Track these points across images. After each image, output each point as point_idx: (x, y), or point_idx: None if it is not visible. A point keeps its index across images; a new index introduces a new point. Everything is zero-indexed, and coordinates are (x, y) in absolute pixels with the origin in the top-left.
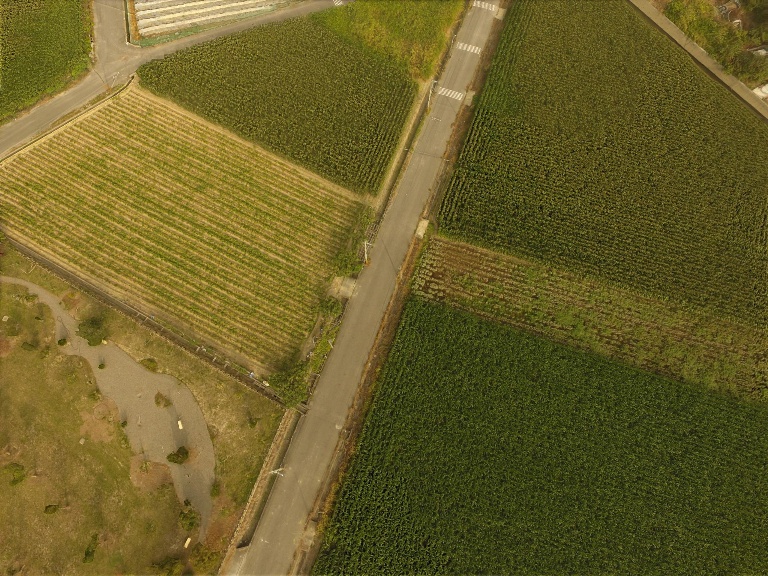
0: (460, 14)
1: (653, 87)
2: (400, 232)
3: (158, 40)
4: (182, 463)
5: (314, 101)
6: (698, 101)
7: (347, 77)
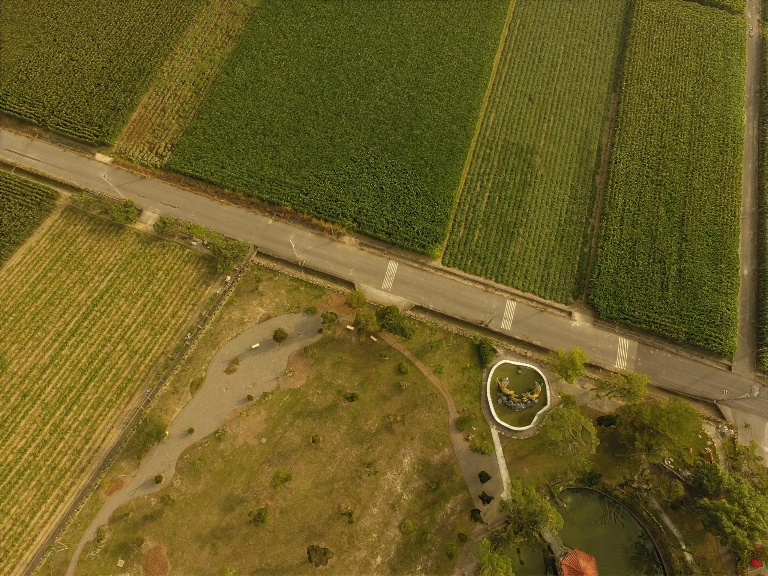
0: None
1: None
2: None
3: None
4: None
5: None
6: None
7: None
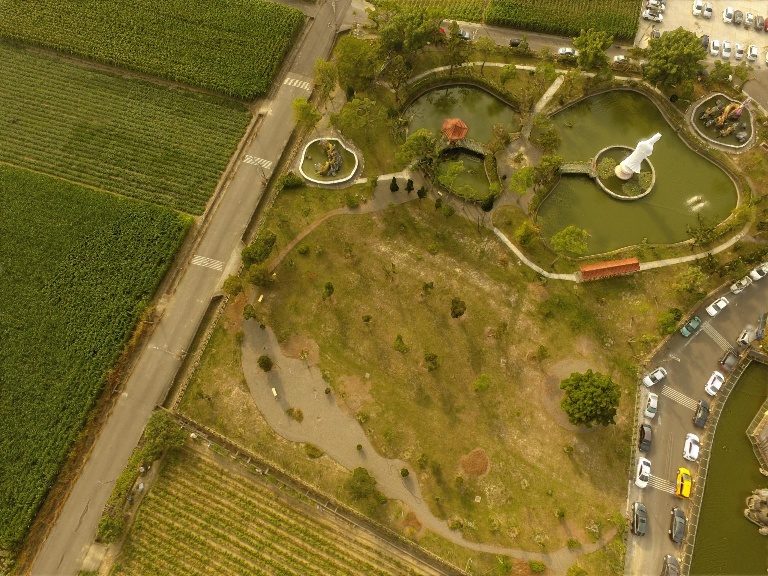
0: None
1: None
2: None
3: None
4: None
5: None
6: None
7: None
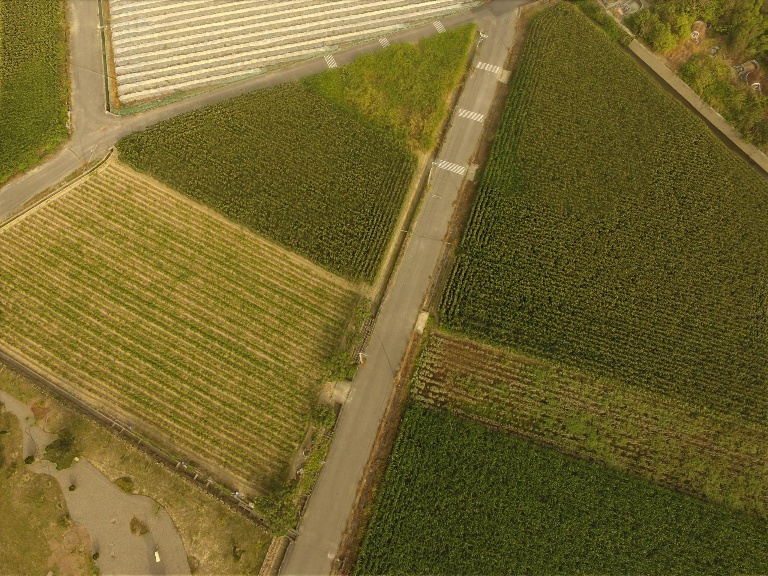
0: (462, 77)
1: (668, 160)
2: (398, 327)
3: (140, 108)
4: None
5: (306, 178)
6: (716, 176)
7: (341, 151)
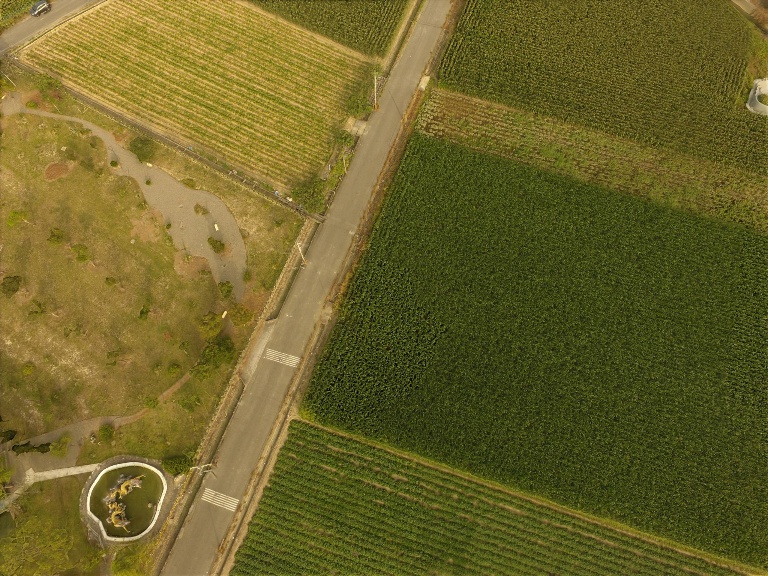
0: None
1: None
2: (405, 85)
3: None
4: (219, 252)
5: None
6: None
7: None
